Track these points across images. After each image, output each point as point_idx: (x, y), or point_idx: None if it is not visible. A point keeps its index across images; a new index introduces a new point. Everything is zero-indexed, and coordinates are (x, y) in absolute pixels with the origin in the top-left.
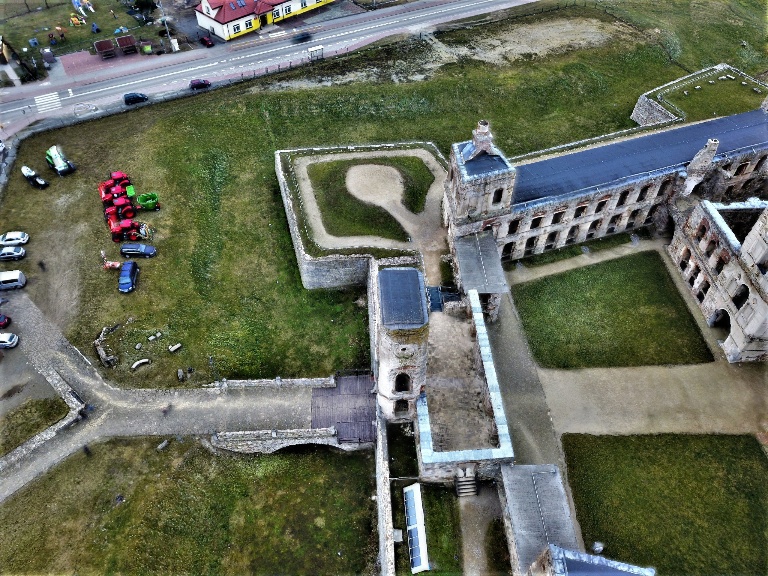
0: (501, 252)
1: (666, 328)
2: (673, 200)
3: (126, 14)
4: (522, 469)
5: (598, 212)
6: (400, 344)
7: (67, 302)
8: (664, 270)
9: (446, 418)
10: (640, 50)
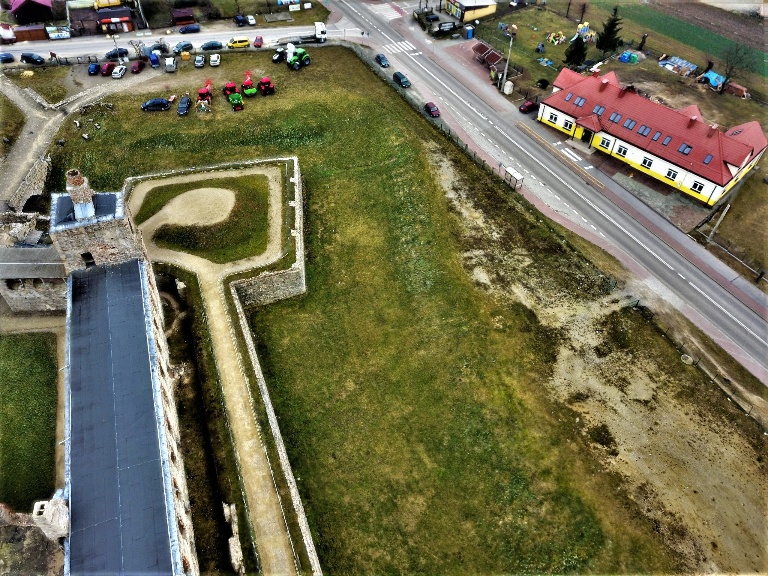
0: None
1: None
2: None
3: None
4: None
5: None
6: None
7: (146, 89)
8: None
9: None
10: None
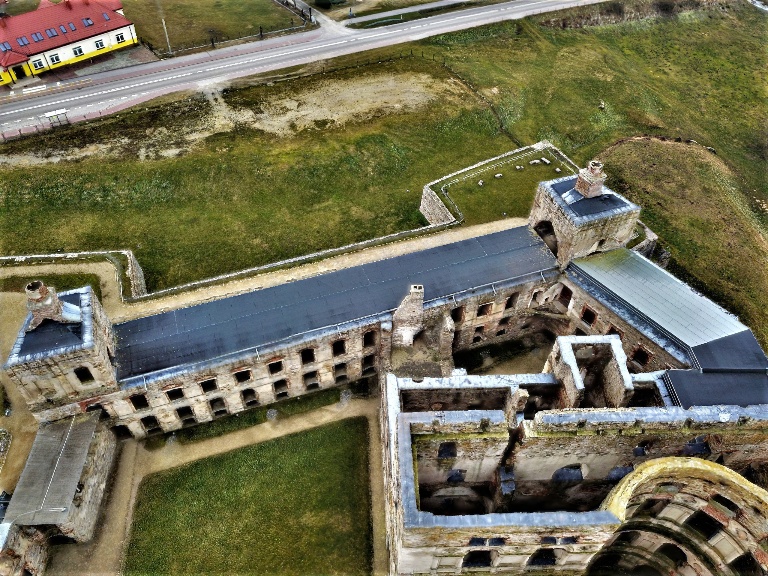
0: (139, 427)
1: (325, 551)
2: (386, 353)
3: None
4: None
5: (277, 372)
6: None
7: None
8: (363, 449)
9: None
10: (464, 117)
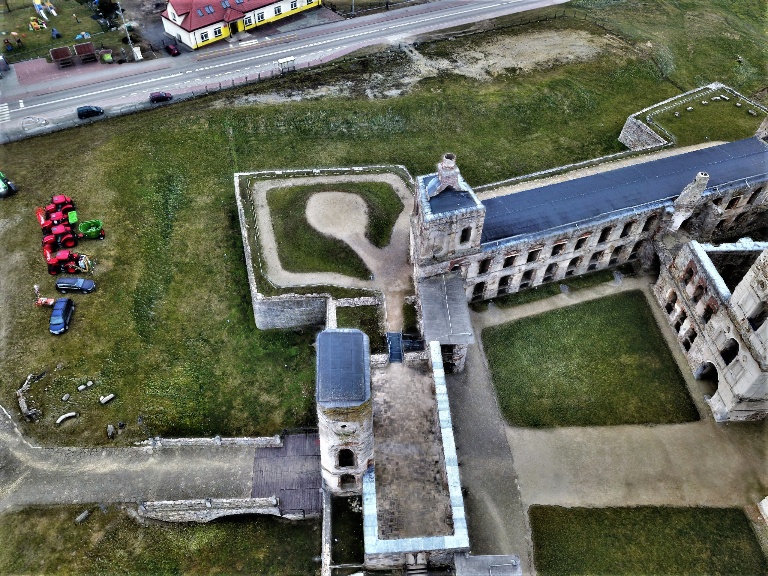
0: (472, 292)
1: (648, 380)
2: (659, 236)
3: (90, 18)
4: (478, 560)
5: (578, 249)
6: (339, 421)
7: None
8: (648, 313)
9: (398, 492)
10: (630, 66)
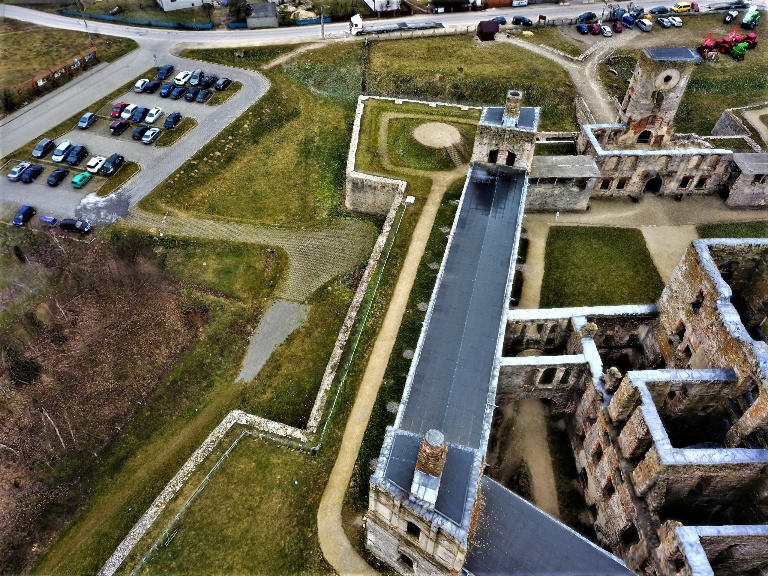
0: None
1: None
2: None
3: None
4: (593, 162)
5: None
6: (639, 66)
7: (642, 45)
8: None
9: None
10: None
